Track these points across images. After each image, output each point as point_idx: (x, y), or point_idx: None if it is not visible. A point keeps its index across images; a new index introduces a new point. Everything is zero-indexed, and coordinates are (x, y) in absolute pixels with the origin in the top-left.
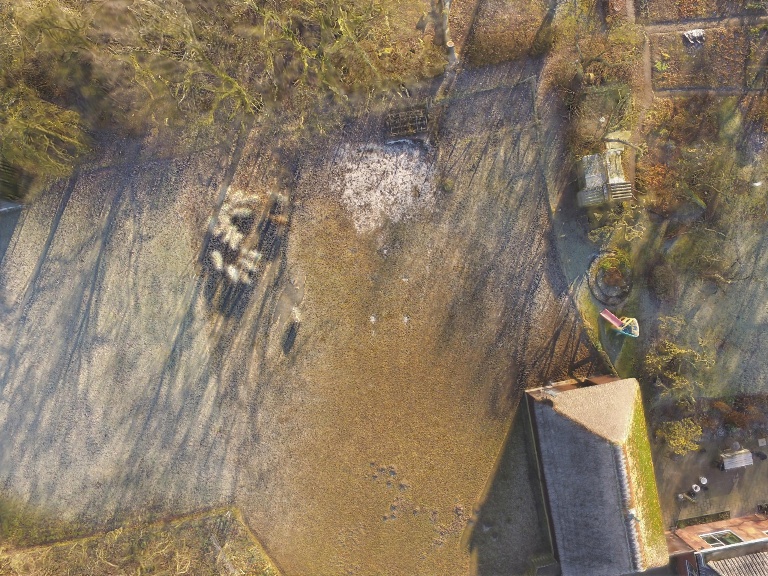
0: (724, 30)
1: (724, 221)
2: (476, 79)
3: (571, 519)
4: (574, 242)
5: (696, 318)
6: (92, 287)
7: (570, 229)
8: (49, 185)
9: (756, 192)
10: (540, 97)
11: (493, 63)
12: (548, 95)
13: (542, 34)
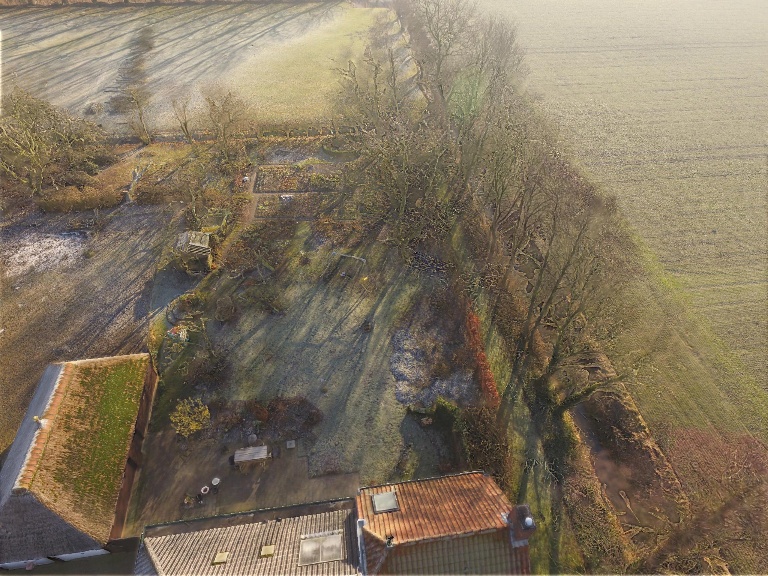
0: (307, 196)
1: (288, 279)
2: (139, 209)
3: (7, 468)
4: (167, 287)
5: (252, 339)
6: None
7: (168, 280)
8: None
9: (315, 265)
10: (177, 217)
11: (154, 203)
12: (183, 217)
13: (178, 186)
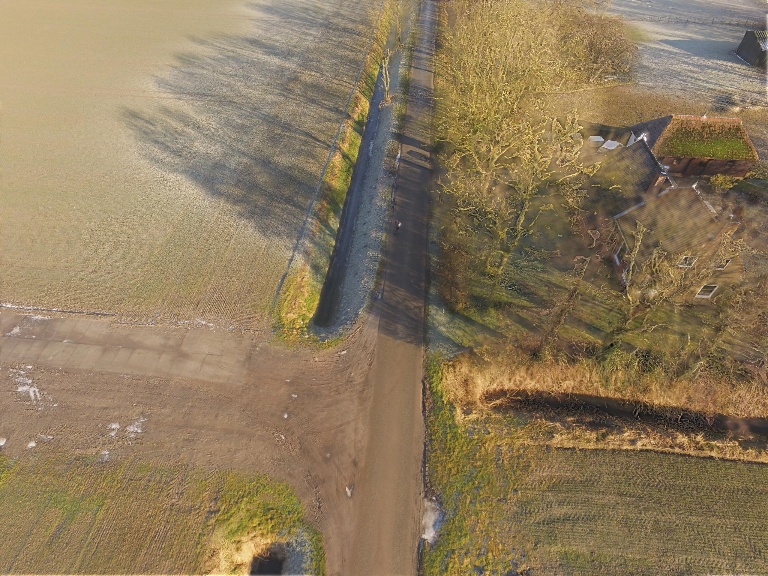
0: None
1: None
2: None
3: None
4: None
5: None
6: (724, 72)
7: None
8: (764, 71)
9: None
10: None
11: None
12: None
13: None
